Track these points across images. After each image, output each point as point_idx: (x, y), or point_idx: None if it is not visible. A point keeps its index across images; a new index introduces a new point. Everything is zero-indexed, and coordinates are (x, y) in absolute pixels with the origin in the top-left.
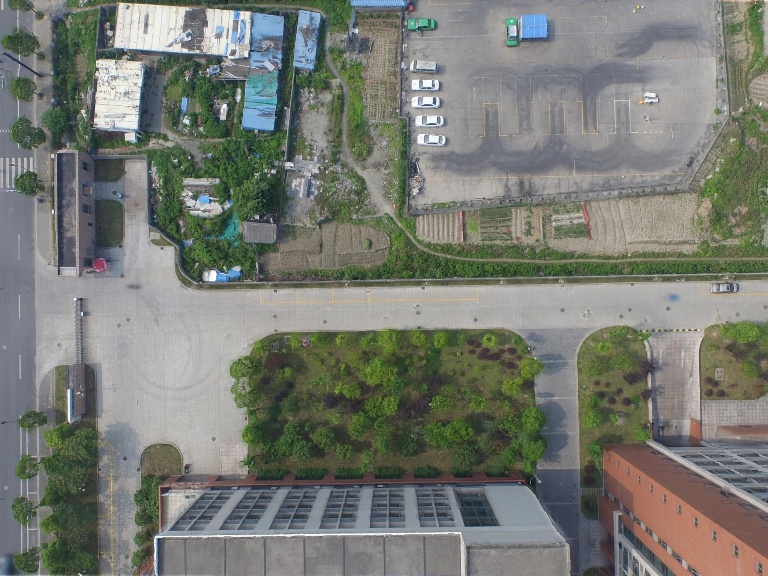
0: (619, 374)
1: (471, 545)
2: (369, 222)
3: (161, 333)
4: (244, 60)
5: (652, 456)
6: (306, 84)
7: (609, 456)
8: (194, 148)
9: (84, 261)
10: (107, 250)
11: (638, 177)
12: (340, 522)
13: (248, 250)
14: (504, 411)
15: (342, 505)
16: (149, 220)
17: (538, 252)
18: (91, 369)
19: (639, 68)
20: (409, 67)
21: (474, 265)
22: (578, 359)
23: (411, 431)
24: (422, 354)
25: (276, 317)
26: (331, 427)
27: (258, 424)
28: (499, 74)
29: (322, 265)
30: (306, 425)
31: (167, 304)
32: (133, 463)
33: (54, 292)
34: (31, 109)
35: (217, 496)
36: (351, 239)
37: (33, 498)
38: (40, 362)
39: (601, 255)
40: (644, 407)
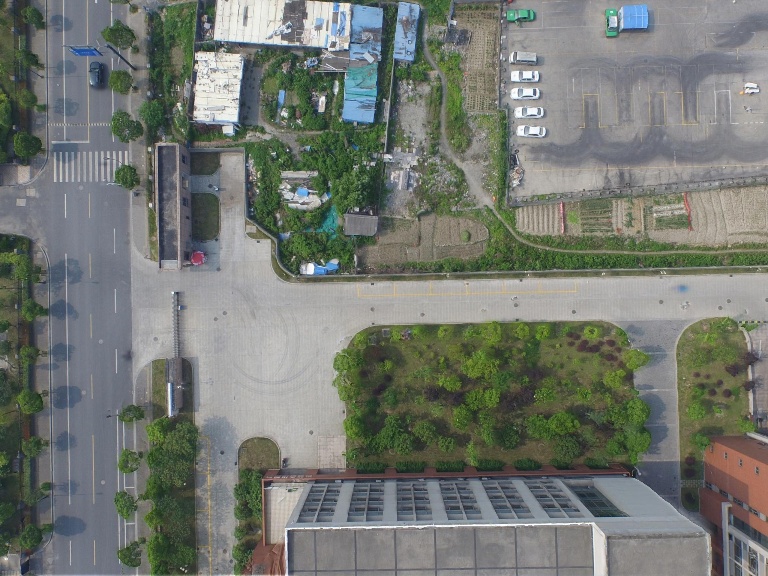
0: (719, 366)
1: (611, 535)
2: (468, 214)
3: (258, 326)
4: (344, 52)
5: (761, 447)
6: (405, 76)
7: (712, 448)
8: (292, 141)
9: (184, 254)
10: (203, 243)
11: (739, 168)
12: (466, 513)
13: (347, 243)
14: (605, 403)
15: (458, 497)
16: (247, 213)
17: (638, 243)
18: (188, 363)
19: (739, 58)
20: (508, 58)
21: (574, 257)
22: (677, 351)
23: (513, 423)
24: (521, 346)
25: (373, 310)
26: (430, 420)
27: (359, 417)
28: (598, 65)
29: (420, 257)
30: (408, 418)
31: (264, 297)
32: (230, 457)
33: (150, 286)
34: (126, 102)
35: (326, 489)
36: (450, 231)
37: (131, 492)
38: (136, 356)
39: (701, 246)
40: (744, 399)
